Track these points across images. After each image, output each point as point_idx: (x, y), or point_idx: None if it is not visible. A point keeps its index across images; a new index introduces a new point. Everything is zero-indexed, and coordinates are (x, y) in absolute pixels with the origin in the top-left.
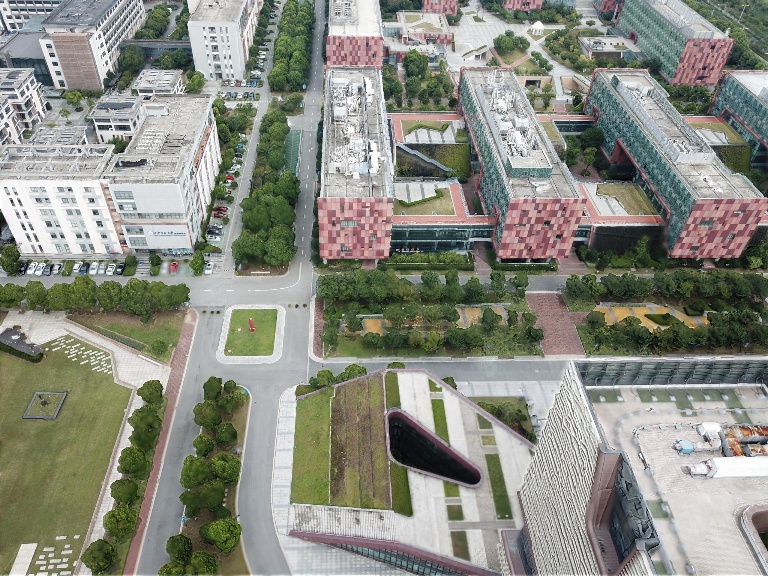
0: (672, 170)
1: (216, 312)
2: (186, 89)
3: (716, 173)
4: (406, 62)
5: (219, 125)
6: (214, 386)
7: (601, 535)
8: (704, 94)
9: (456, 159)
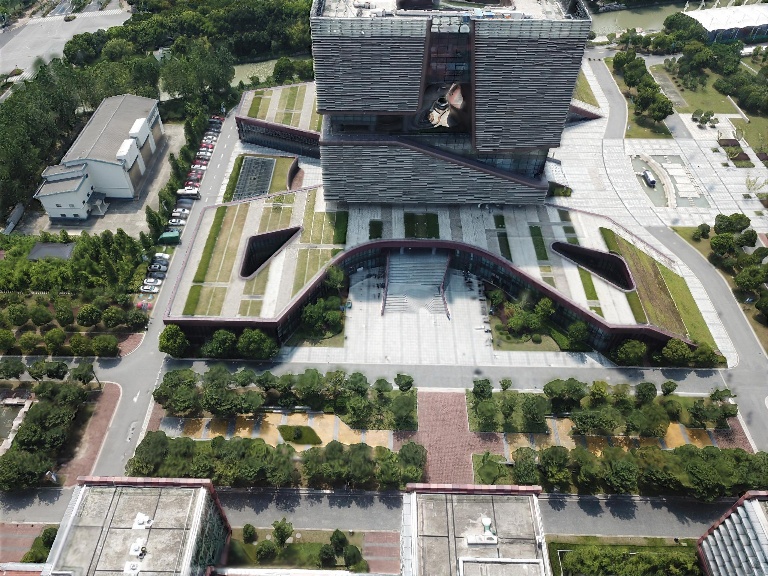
0: None
1: None
2: None
3: None
4: None
5: None
6: None
7: None
8: None
9: None
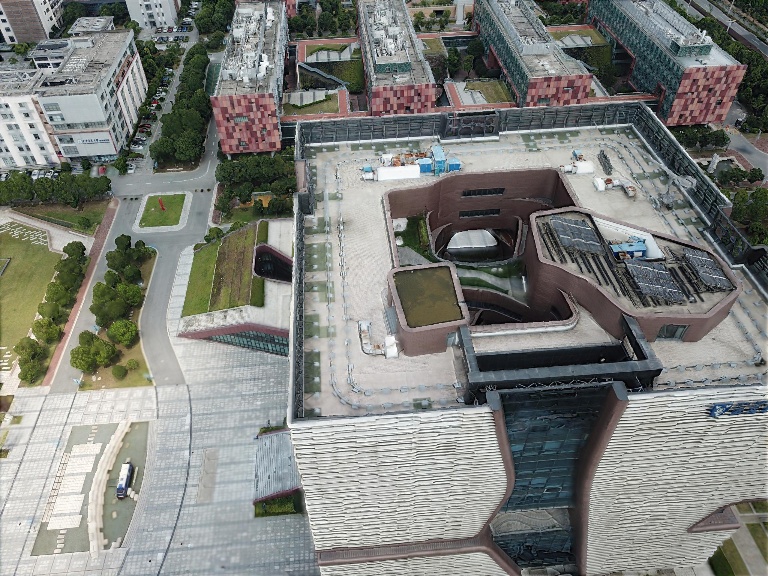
0: (518, 60)
1: (135, 198)
2: None
3: (555, 60)
4: (320, 0)
5: (147, 60)
6: (123, 240)
7: None
8: (585, 8)
9: (352, 74)
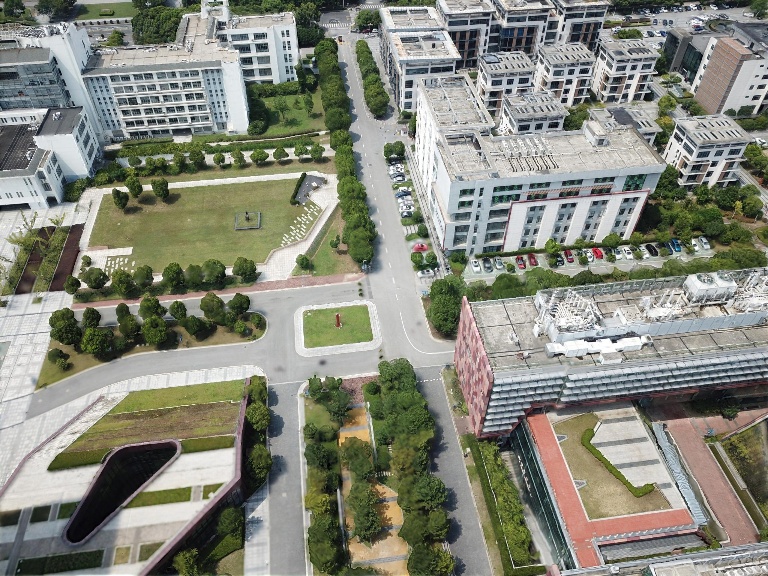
0: None
1: (360, 292)
2: (765, 169)
3: None
4: None
5: None
6: (234, 299)
7: None
8: None
9: None
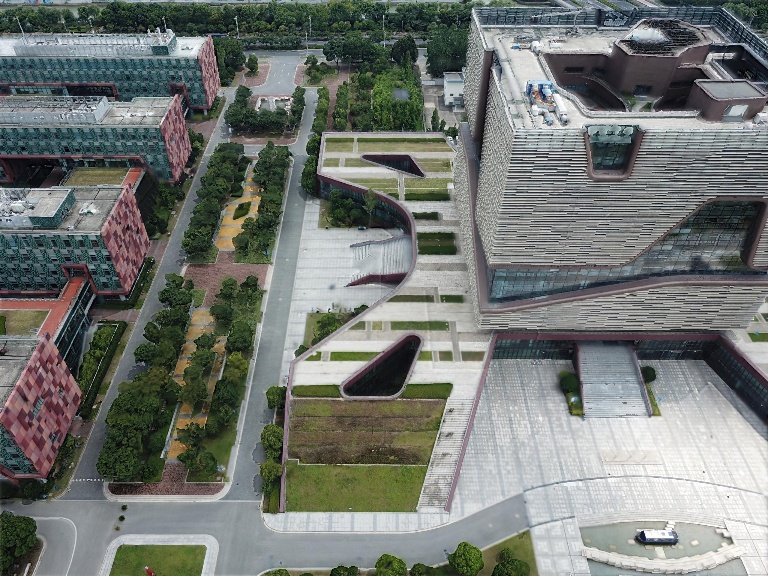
0: (106, 128)
1: None
2: None
3: (125, 108)
4: None
5: None
6: None
7: (599, 173)
8: None
9: None
